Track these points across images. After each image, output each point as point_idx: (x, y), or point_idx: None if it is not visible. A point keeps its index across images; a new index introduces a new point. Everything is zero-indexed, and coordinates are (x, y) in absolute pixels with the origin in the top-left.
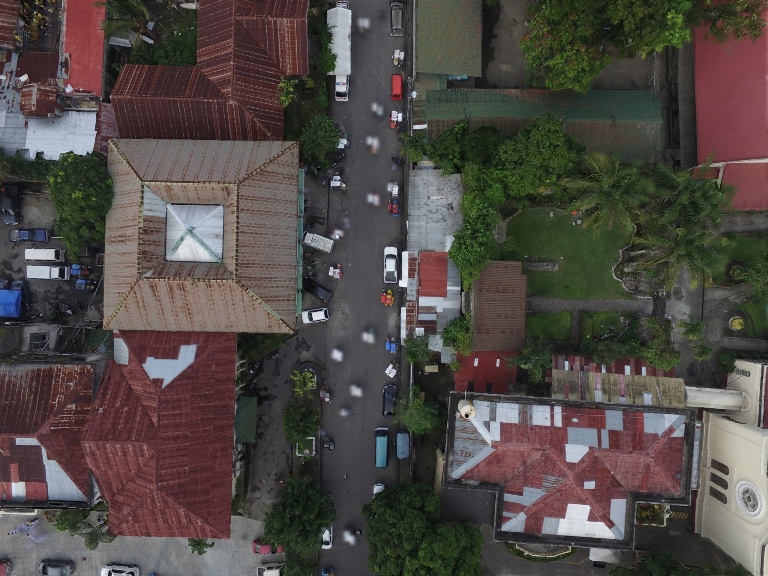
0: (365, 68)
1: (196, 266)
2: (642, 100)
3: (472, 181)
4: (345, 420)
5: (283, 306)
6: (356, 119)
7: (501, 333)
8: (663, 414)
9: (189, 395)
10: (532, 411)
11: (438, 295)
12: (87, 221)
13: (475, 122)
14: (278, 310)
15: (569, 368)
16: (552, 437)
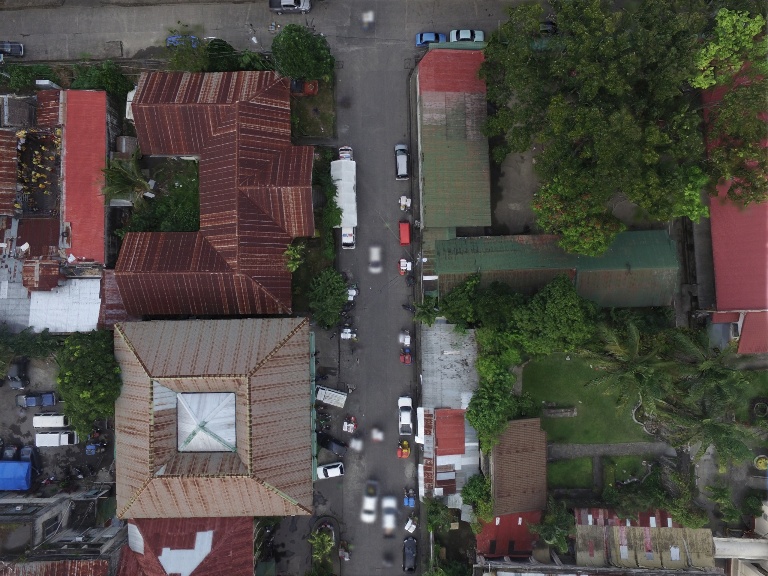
0: (371, 213)
1: (209, 458)
2: (657, 243)
3: (487, 346)
4: (365, 575)
5: (299, 490)
6: (364, 266)
7: (522, 494)
8: None
9: None
10: None
11: (456, 453)
12: None
13: (487, 275)
14: (295, 495)
15: (593, 522)
16: None
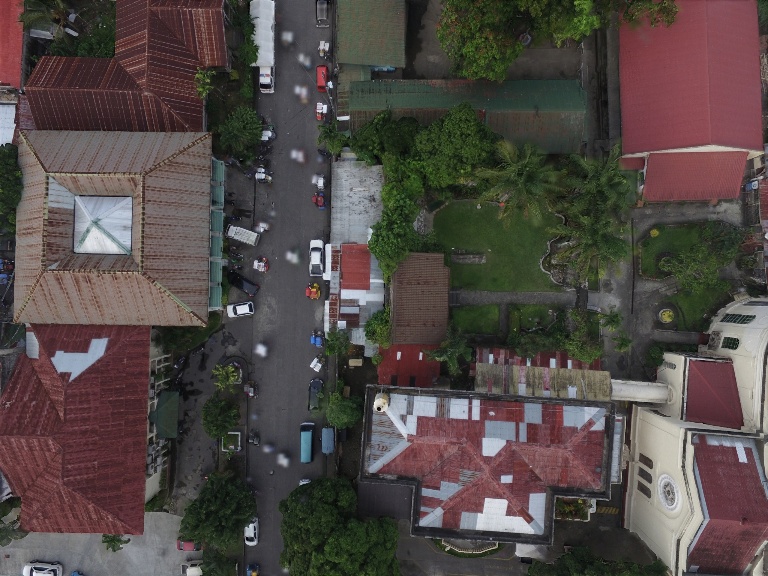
0: (292, 60)
1: (103, 258)
2: (567, 90)
3: (389, 172)
4: (271, 415)
5: (194, 299)
6: (282, 111)
7: (422, 326)
8: (583, 407)
9: (98, 389)
10: (450, 404)
11: (361, 288)
12: None
13: (397, 113)
14: (189, 303)
15: (493, 361)
16: (469, 431)
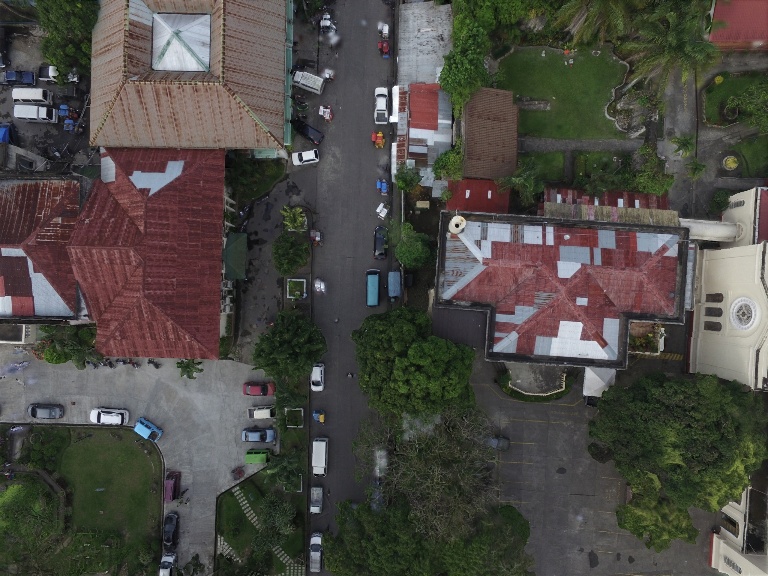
0: None
1: (183, 73)
2: None
3: (462, 1)
4: (336, 263)
5: (271, 119)
6: None
7: (492, 161)
8: (656, 234)
9: (176, 207)
10: (524, 231)
11: (429, 128)
12: (73, 40)
13: None
14: (266, 122)
15: (561, 201)
16: (544, 254)
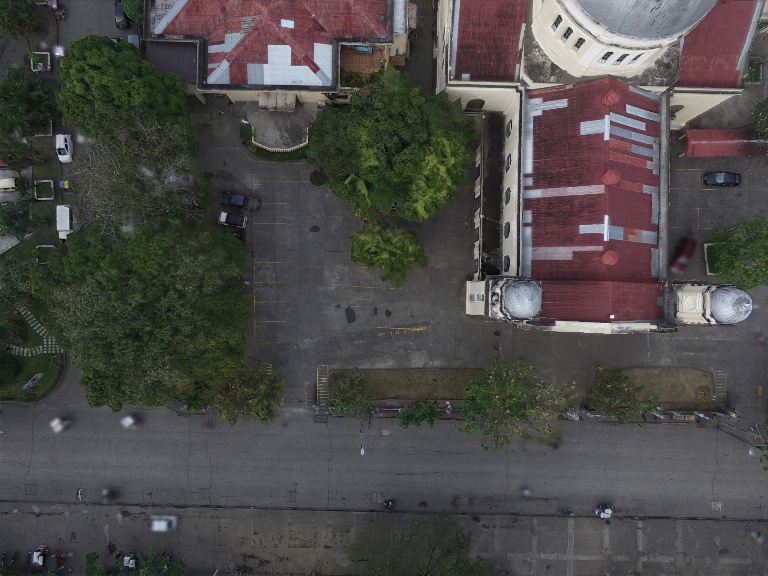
0: None
1: None
2: None
3: None
4: (81, 37)
5: None
6: None
7: None
8: None
9: None
10: None
11: None
12: None
13: None
14: None
15: None
16: None
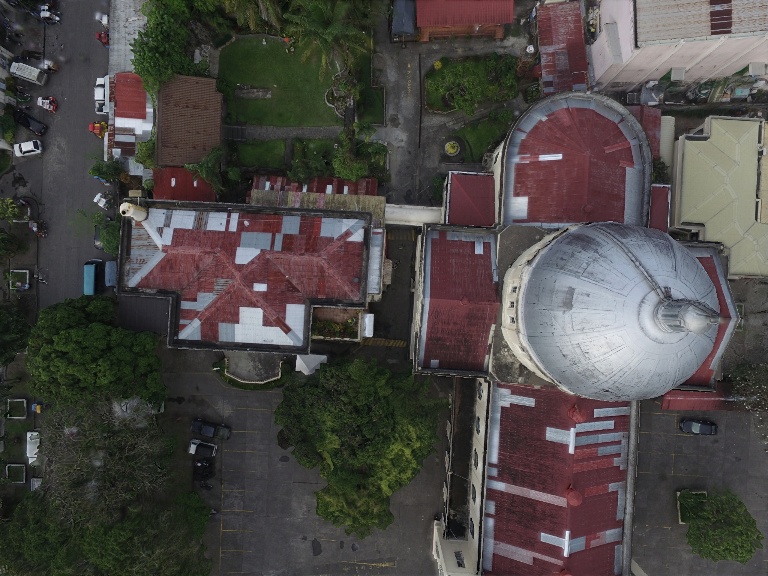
0: None
1: None
2: None
3: None
4: (61, 254)
5: None
6: None
7: (192, 149)
8: (341, 219)
9: None
10: (208, 217)
11: (136, 117)
12: None
13: None
14: None
15: (269, 188)
16: (224, 241)
